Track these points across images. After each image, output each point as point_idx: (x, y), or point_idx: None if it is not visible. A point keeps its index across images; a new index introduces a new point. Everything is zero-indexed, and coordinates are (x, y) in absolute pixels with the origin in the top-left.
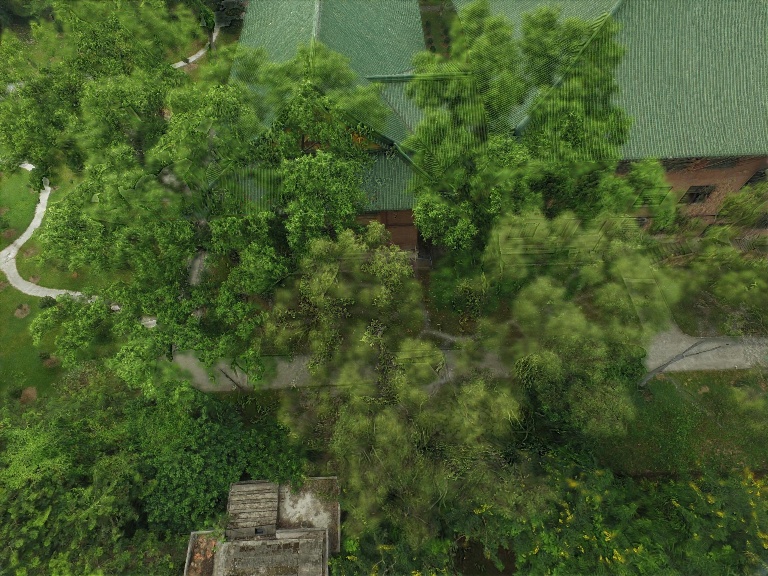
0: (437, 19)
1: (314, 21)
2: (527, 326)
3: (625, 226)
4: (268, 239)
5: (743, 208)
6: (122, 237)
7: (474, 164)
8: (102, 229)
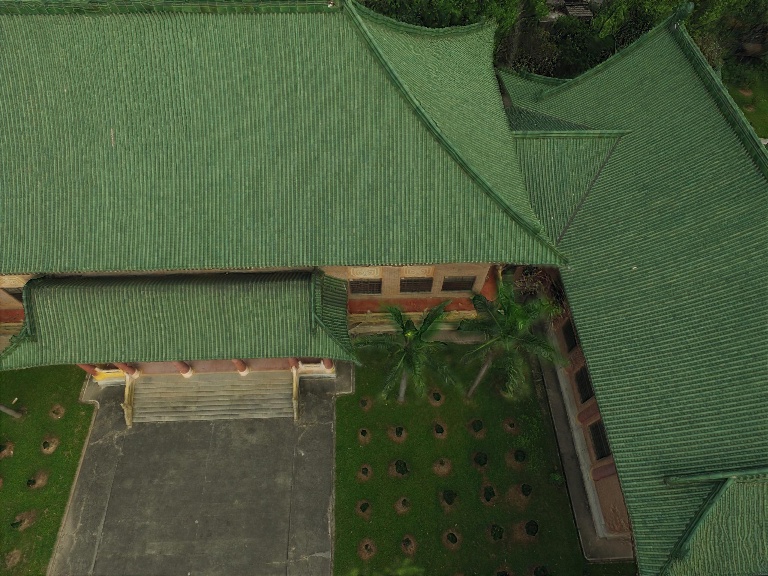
0: None
1: None
2: None
3: None
4: None
5: None
6: None
7: None
8: None
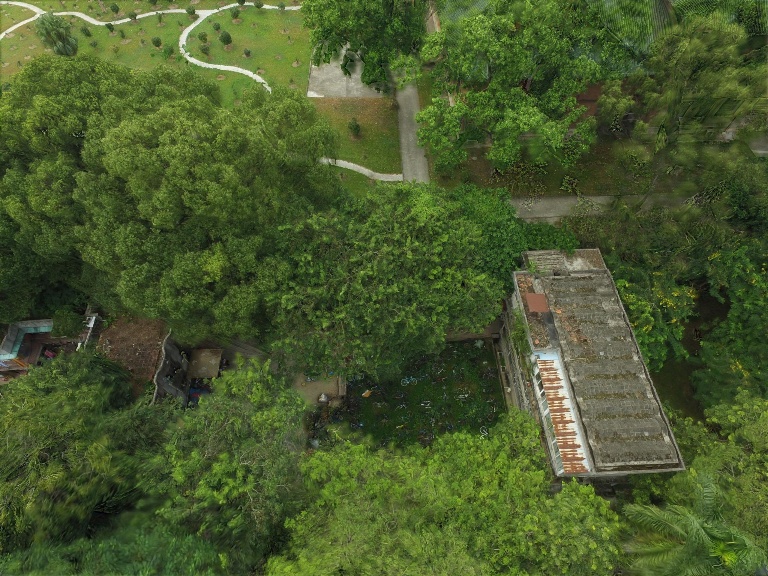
0: None
1: None
2: None
3: (756, 107)
4: (592, 53)
5: None
6: (528, 35)
7: (692, 27)
8: (514, 30)
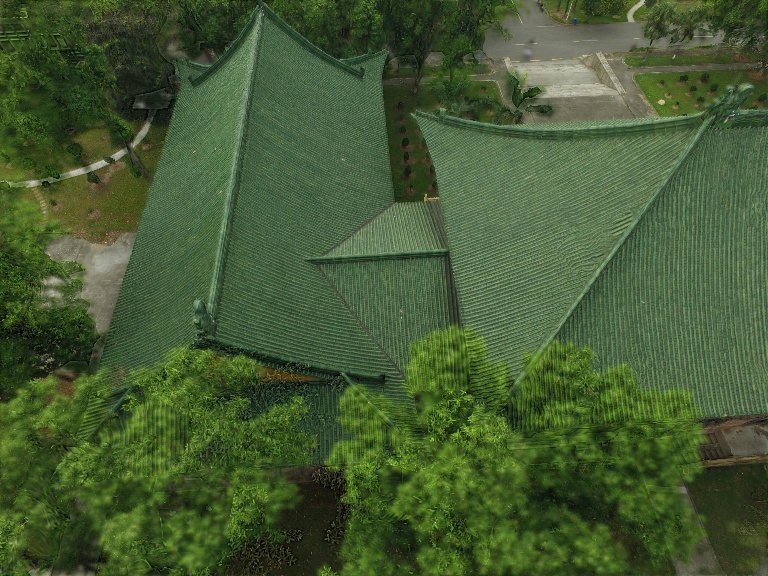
0: (411, 97)
1: (226, 207)
2: (526, 573)
3: None
4: None
5: None
6: None
7: (448, 466)
8: None
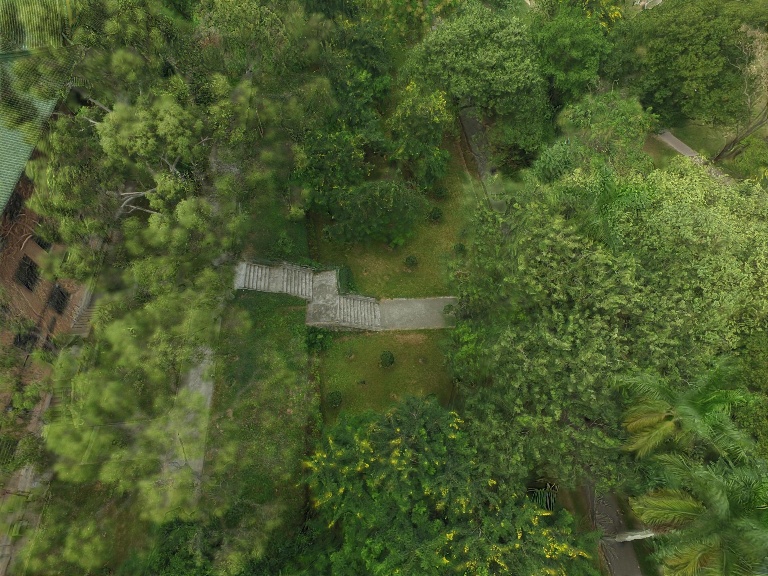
0: None
1: None
2: None
3: (1, 461)
4: None
5: (29, 326)
6: None
7: None
8: None
